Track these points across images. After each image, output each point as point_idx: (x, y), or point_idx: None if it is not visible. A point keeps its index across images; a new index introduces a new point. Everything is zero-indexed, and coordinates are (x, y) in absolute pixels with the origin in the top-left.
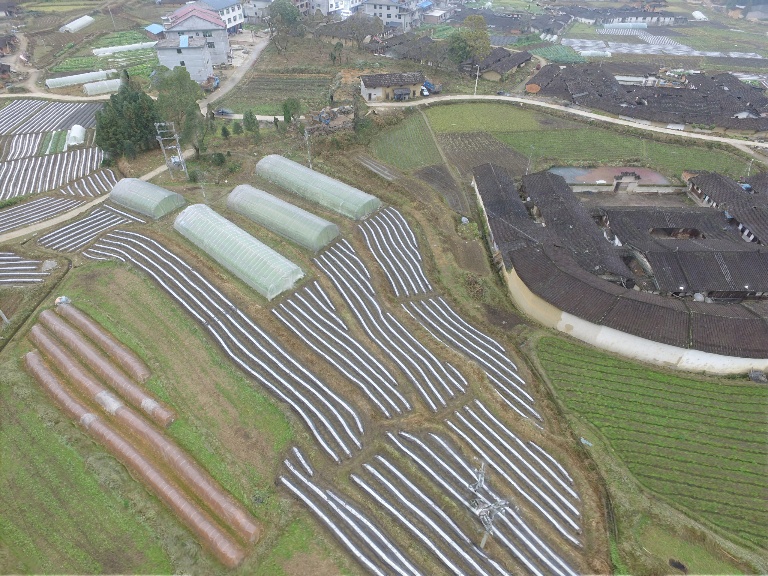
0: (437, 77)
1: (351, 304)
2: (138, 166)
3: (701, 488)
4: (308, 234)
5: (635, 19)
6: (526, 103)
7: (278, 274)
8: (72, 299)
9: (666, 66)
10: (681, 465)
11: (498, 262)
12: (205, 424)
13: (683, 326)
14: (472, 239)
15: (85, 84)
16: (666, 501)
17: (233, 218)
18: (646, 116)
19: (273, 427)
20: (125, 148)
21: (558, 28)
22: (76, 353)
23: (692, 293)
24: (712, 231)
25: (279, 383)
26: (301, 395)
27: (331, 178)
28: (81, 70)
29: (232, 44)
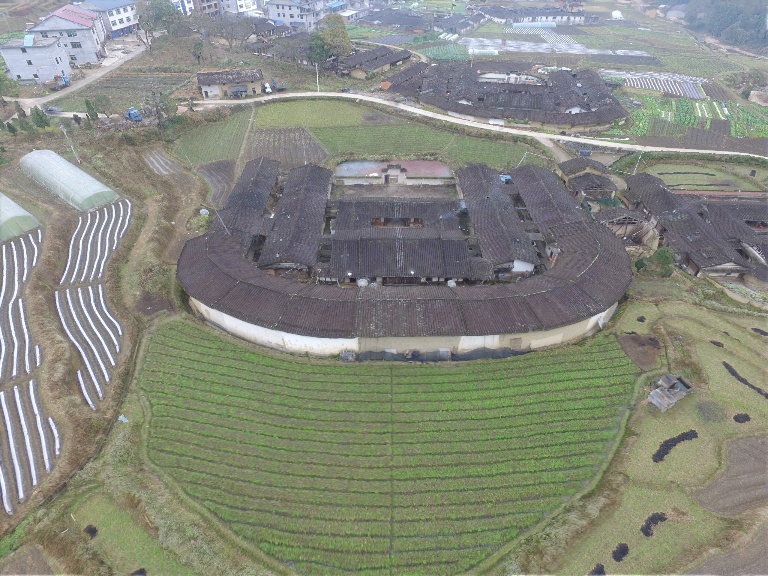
0: (297, 75)
1: None
2: None
3: (203, 461)
4: None
5: (545, 18)
6: (362, 100)
7: None
8: None
9: (542, 64)
10: (202, 440)
11: None
12: None
13: (281, 308)
14: (195, 230)
15: None
16: (157, 473)
17: None
18: (470, 111)
19: None
20: None
21: (461, 27)
22: None
23: (358, 279)
24: (431, 220)
25: None
26: None
27: (81, 172)
28: None
29: (118, 44)
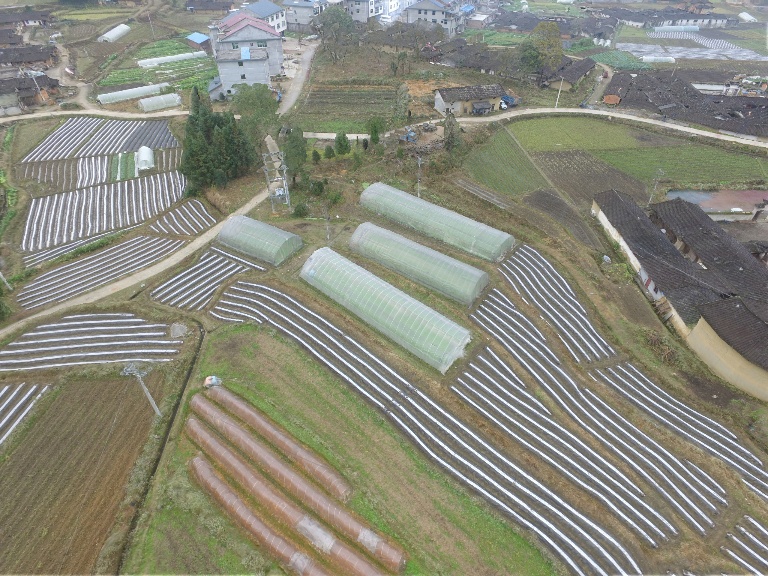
0: (506, 88)
1: (538, 377)
2: (230, 197)
3: None
4: (461, 286)
5: (686, 22)
6: (615, 117)
7: (451, 342)
8: (222, 379)
9: (739, 73)
10: None
11: (665, 312)
12: (443, 565)
13: None
14: (625, 283)
15: (141, 100)
16: None
17: (362, 263)
18: (752, 131)
19: (530, 569)
20: (216, 177)
21: (610, 32)
22: (250, 457)
23: None
24: None
25: (506, 497)
26: (541, 516)
27: (451, 211)
28: (130, 83)
29: None
